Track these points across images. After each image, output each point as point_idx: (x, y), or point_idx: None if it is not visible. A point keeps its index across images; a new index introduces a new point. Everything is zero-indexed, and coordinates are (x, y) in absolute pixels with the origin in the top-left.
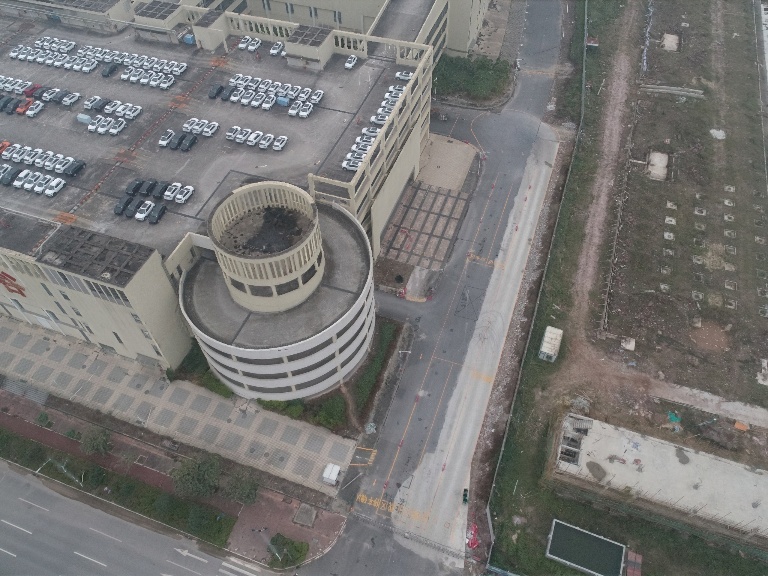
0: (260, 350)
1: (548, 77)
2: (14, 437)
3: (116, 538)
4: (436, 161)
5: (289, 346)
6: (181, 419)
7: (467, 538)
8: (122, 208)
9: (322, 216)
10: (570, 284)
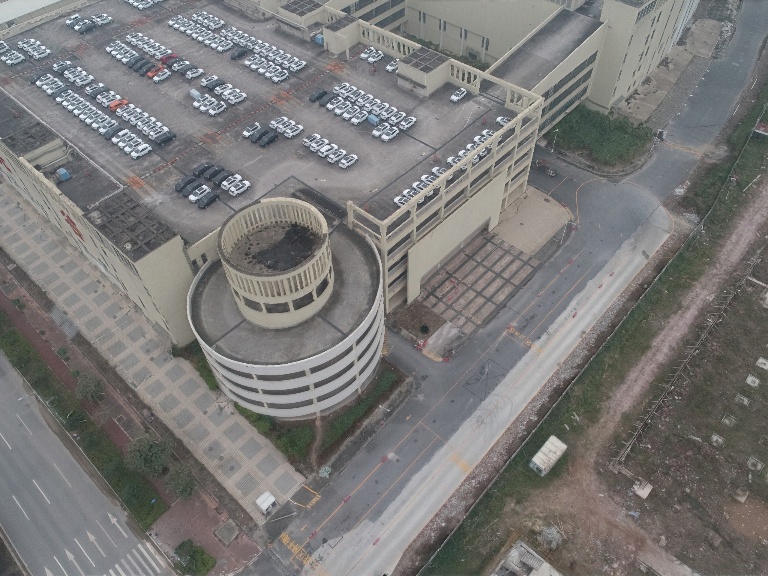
0: (230, 360)
1: (693, 157)
2: (37, 359)
3: (69, 482)
4: (522, 217)
5: (256, 366)
6: (167, 395)
7: None
8: (182, 186)
9: (352, 246)
10: (605, 397)
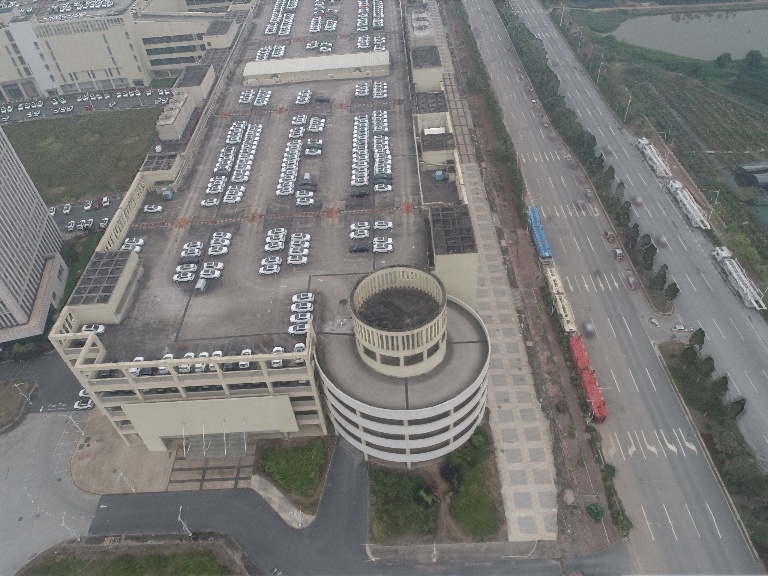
0: None
1: None
2: None
3: (471, 7)
4: None
5: None
6: None
7: None
8: None
9: None
10: None
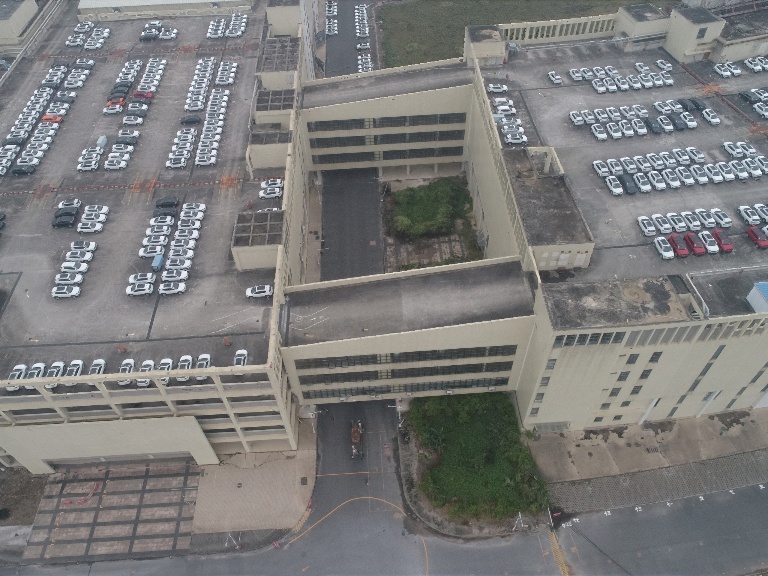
0: None
1: None
2: None
3: None
4: (252, 477)
5: None
6: None
7: None
8: None
9: None
10: None
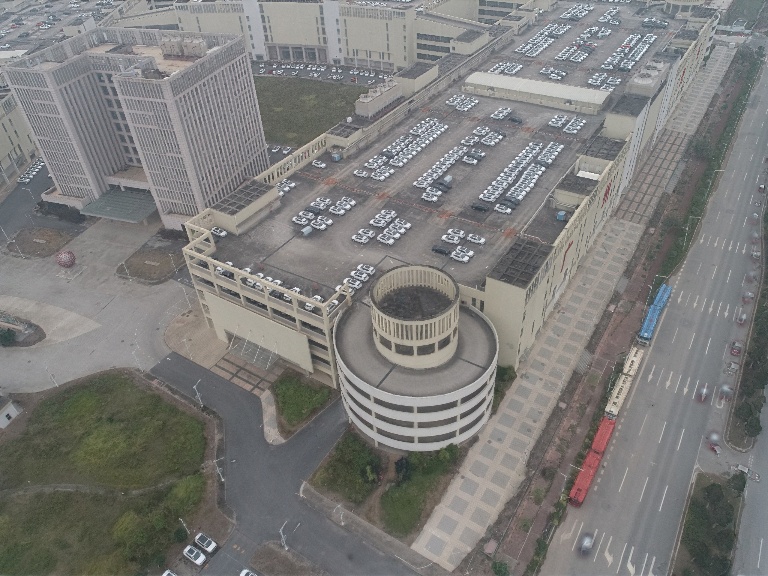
0: None
1: None
2: None
3: None
4: None
5: None
6: (720, 66)
7: (742, 36)
8: None
9: (655, 7)
10: None
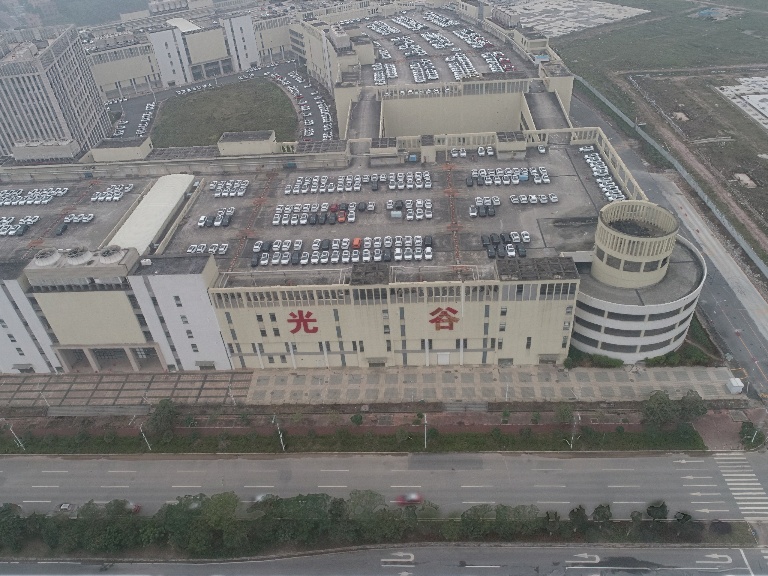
0: (674, 302)
1: (626, 149)
2: (489, 435)
3: (628, 469)
4: None
5: (690, 295)
6: (598, 389)
7: None
8: (494, 252)
9: None
10: (764, 251)
